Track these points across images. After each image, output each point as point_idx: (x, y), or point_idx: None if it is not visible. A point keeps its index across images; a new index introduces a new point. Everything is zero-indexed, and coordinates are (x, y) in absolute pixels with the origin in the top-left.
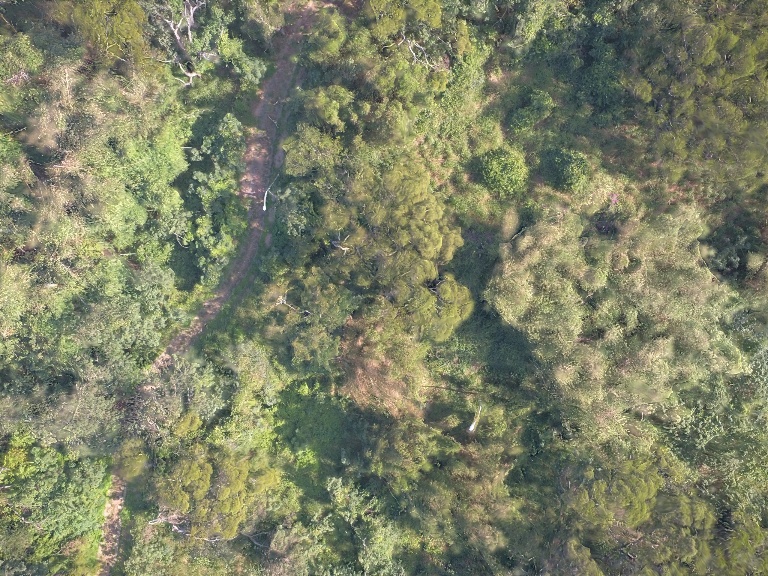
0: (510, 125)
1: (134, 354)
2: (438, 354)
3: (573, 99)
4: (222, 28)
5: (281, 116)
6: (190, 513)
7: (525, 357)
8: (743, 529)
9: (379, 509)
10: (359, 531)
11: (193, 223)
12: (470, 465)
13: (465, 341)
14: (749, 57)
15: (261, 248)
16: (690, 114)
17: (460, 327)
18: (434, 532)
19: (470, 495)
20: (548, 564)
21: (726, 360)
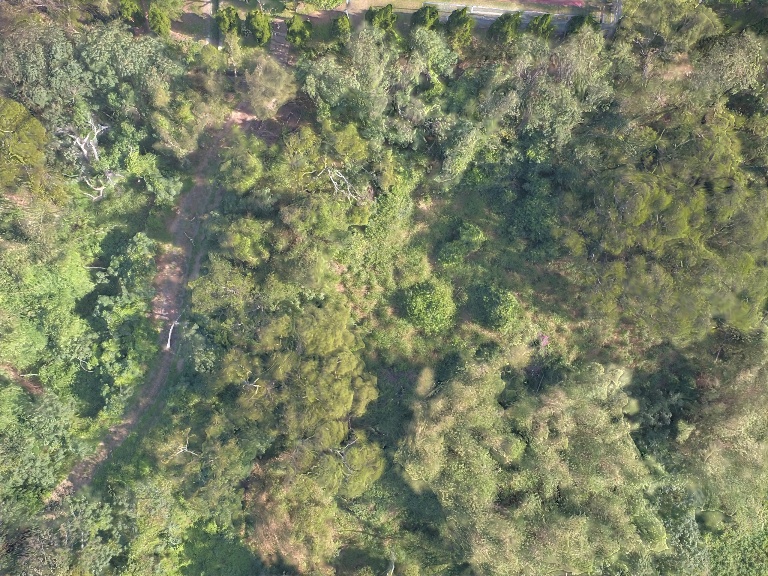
0: (437, 258)
1: (29, 487)
2: (354, 500)
3: (505, 232)
4: (131, 147)
5: (198, 233)
6: None
7: None
8: None
9: None
10: None
11: (99, 345)
12: None
13: (382, 489)
14: (681, 221)
15: (172, 374)
16: (618, 275)
17: (377, 473)
18: None
19: None
20: None
21: (649, 538)
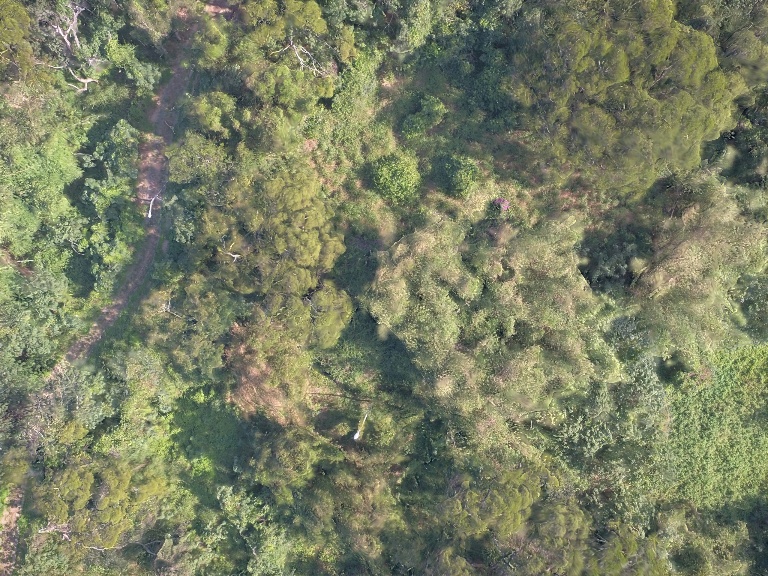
0: (402, 131)
1: (28, 362)
2: (330, 362)
3: (466, 104)
4: (109, 34)
5: (178, 122)
6: (69, 523)
7: (414, 365)
8: (617, 540)
9: (272, 517)
10: (250, 540)
11: (89, 230)
12: (354, 474)
13: (355, 349)
14: (621, 63)
15: (158, 255)
16: (565, 121)
17: (351, 334)
18: (318, 541)
19: (353, 504)
20: (423, 574)
21: (602, 369)
